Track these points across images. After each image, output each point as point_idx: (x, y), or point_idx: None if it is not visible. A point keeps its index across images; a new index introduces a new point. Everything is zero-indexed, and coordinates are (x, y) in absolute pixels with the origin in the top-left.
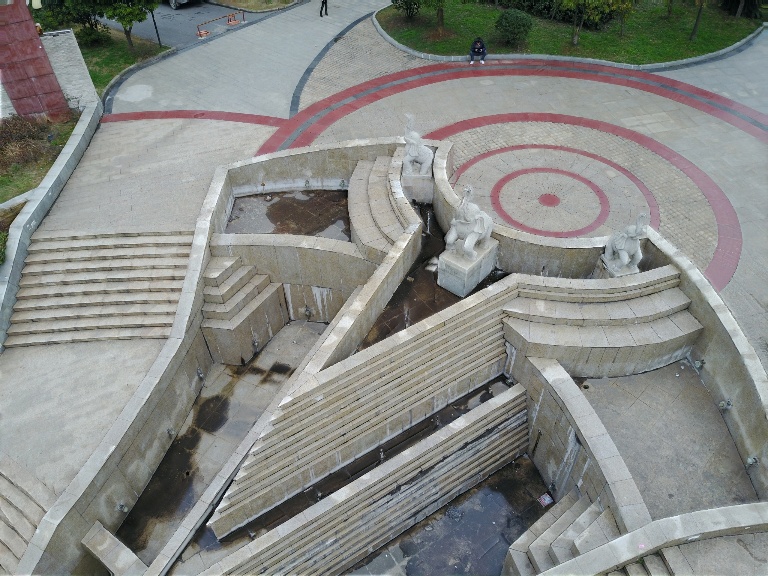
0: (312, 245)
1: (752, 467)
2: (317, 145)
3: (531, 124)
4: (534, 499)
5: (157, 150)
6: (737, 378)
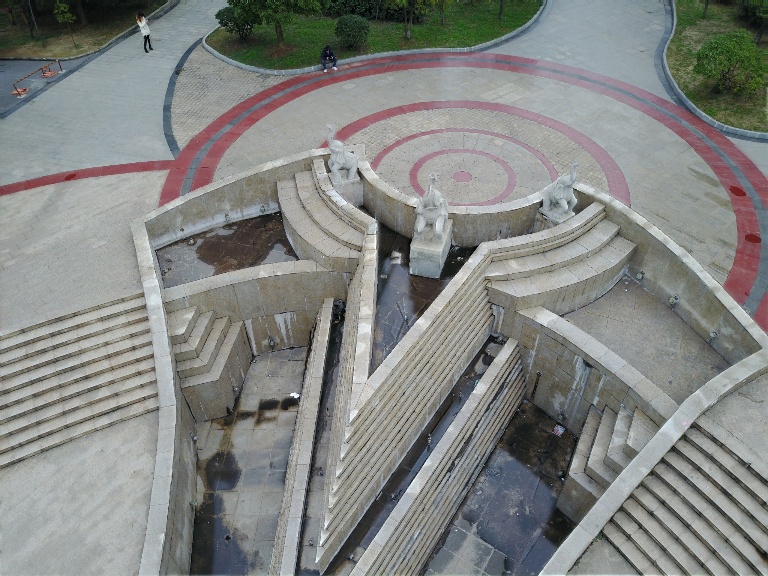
0: (271, 273)
1: (713, 340)
2: (230, 176)
3: (410, 115)
4: (549, 433)
5: (42, 223)
6: (679, 275)
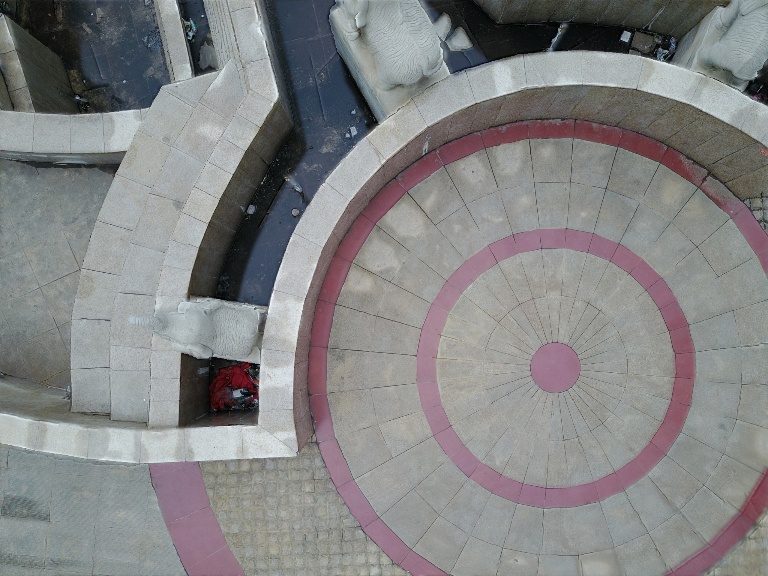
0: None
1: None
2: None
3: None
4: None
5: None
6: None
